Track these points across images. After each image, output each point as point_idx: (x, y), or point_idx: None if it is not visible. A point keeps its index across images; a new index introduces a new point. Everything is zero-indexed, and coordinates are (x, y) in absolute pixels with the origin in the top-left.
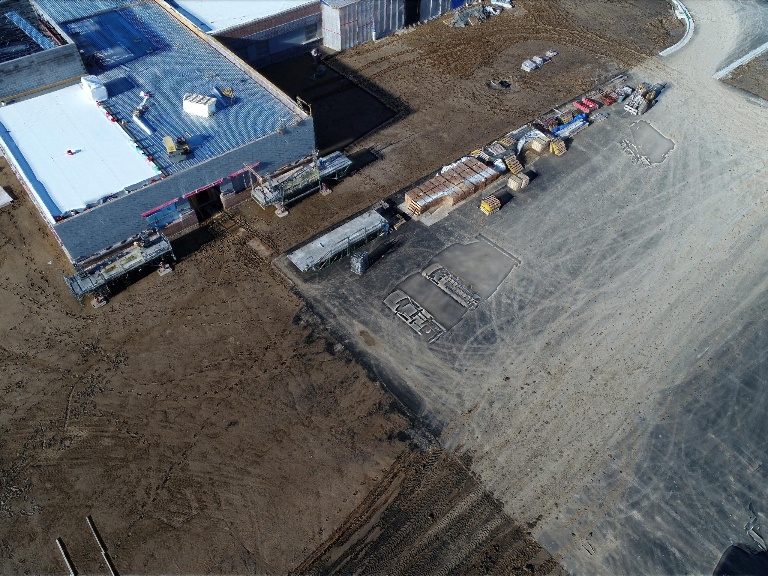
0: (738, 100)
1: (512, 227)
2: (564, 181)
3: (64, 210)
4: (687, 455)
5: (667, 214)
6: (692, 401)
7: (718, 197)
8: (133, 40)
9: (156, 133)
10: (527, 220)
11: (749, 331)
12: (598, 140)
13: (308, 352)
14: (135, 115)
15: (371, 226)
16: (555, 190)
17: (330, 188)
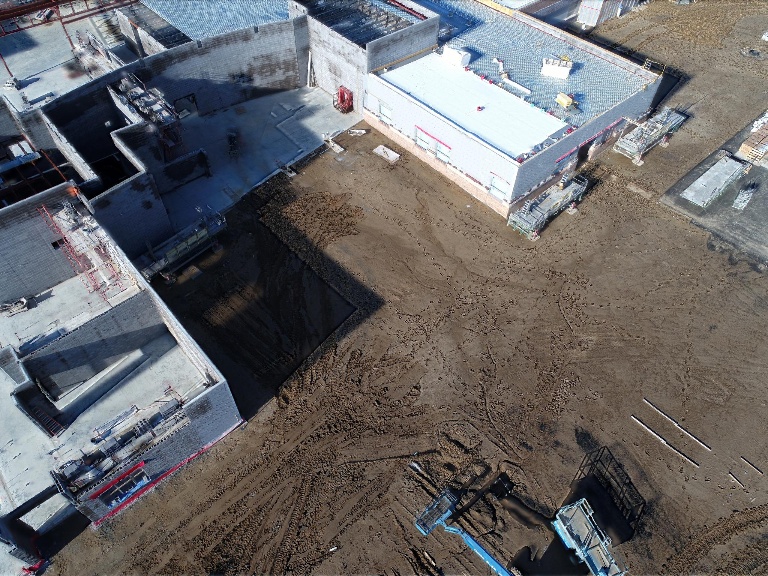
0: None
1: None
2: None
3: (514, 154)
4: None
5: None
6: None
7: None
8: (446, 16)
9: (534, 92)
10: None
11: None
12: None
13: (738, 271)
14: (506, 78)
15: (734, 169)
16: None
17: (666, 141)
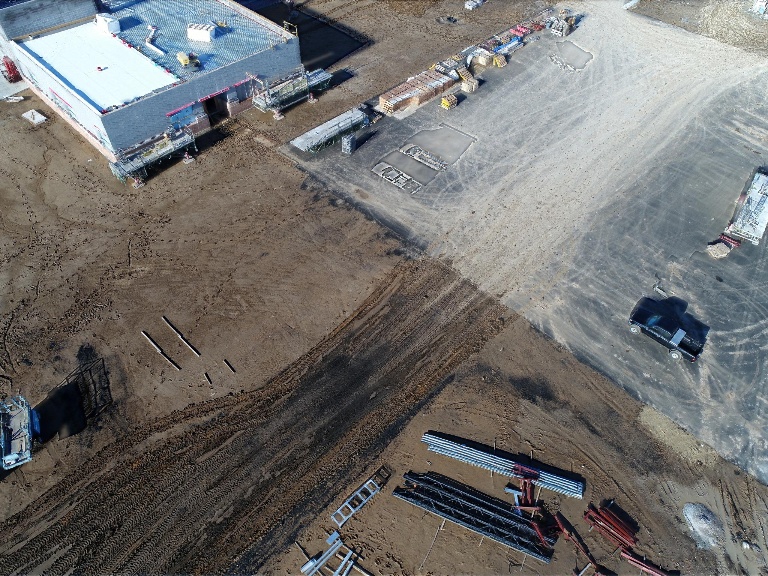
0: (642, 23)
1: (468, 117)
2: (507, 84)
3: (106, 107)
4: (610, 249)
5: (589, 102)
6: (612, 217)
7: (628, 89)
8: None
9: (168, 54)
10: (479, 112)
11: (653, 173)
12: (532, 55)
13: (316, 206)
14: (148, 42)
15: None
16: (500, 91)
17: (316, 98)
